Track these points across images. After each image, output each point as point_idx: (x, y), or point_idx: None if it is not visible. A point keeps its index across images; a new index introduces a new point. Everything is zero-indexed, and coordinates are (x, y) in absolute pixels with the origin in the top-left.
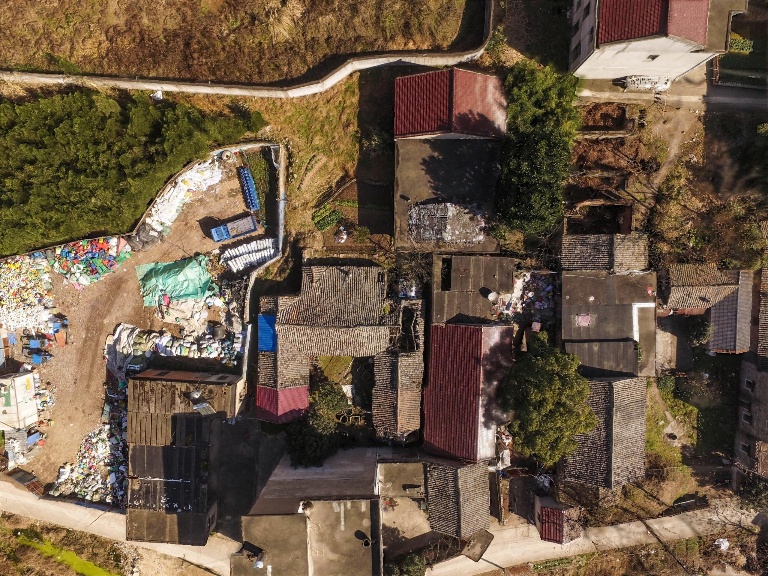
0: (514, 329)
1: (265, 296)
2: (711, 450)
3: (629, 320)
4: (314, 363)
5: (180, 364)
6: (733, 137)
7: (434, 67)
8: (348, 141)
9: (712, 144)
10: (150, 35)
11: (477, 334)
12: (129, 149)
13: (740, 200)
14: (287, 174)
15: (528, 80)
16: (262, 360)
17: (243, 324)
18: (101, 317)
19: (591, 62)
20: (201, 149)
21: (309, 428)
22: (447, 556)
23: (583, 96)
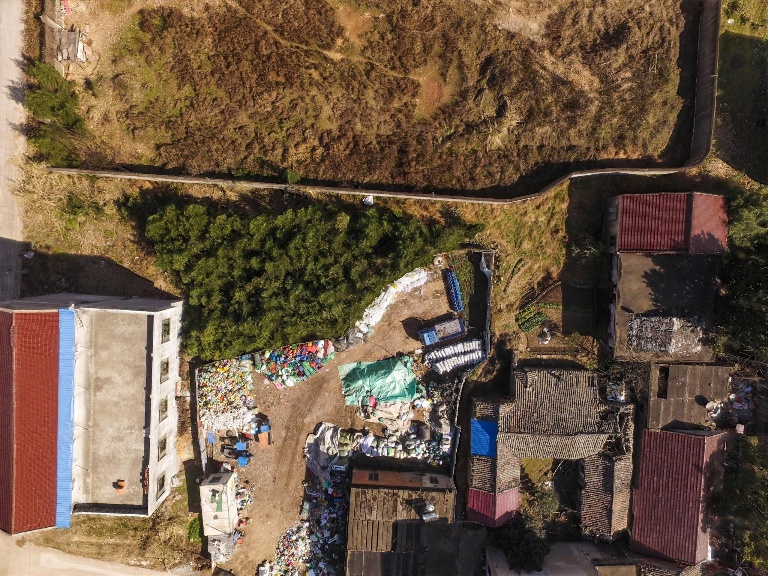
0: (712, 428)
1: (481, 402)
2: None
3: None
4: None
5: (384, 463)
6: None
7: (642, 175)
8: (555, 246)
9: None
10: (365, 141)
11: (699, 443)
12: (355, 260)
13: None
14: None
15: (764, 205)
16: (476, 464)
17: (450, 425)
18: (302, 416)
19: None
20: (428, 261)
21: (530, 533)
22: None
23: None
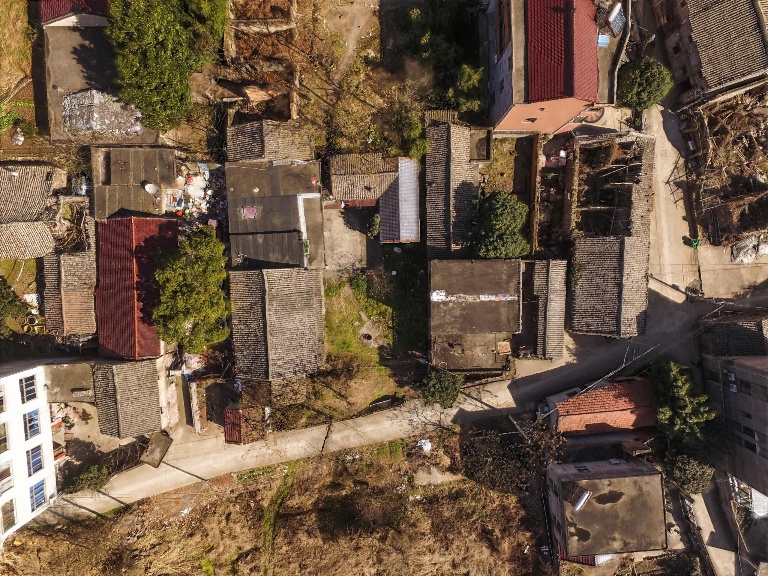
0: None
1: None
2: (407, 350)
3: (295, 211)
4: None
5: None
6: (406, 31)
7: None
8: (20, 38)
9: (387, 38)
10: None
11: (129, 225)
12: None
13: (403, 89)
14: None
15: None
16: None
17: None
18: None
19: None
20: None
21: None
22: (127, 464)
23: None
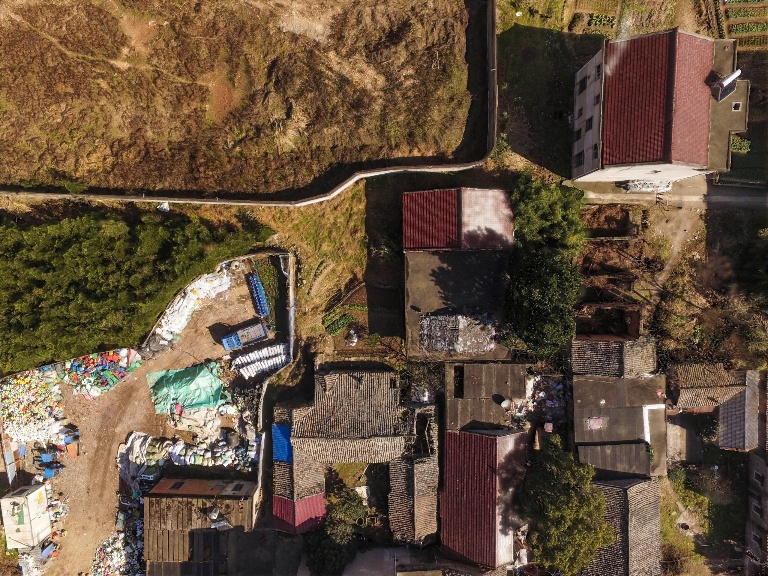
0: (526, 427)
1: (279, 407)
2: (723, 538)
3: (640, 422)
4: (328, 466)
5: (194, 472)
6: (734, 235)
7: (439, 173)
8: (356, 246)
9: (714, 242)
10: (155, 148)
11: (492, 444)
12: (138, 268)
13: (744, 300)
14: (296, 279)
15: (535, 198)
16: (277, 470)
17: (256, 431)
18: (112, 426)
19: (595, 174)
20: (211, 266)
21: (327, 540)
22: None
23: (587, 198)
